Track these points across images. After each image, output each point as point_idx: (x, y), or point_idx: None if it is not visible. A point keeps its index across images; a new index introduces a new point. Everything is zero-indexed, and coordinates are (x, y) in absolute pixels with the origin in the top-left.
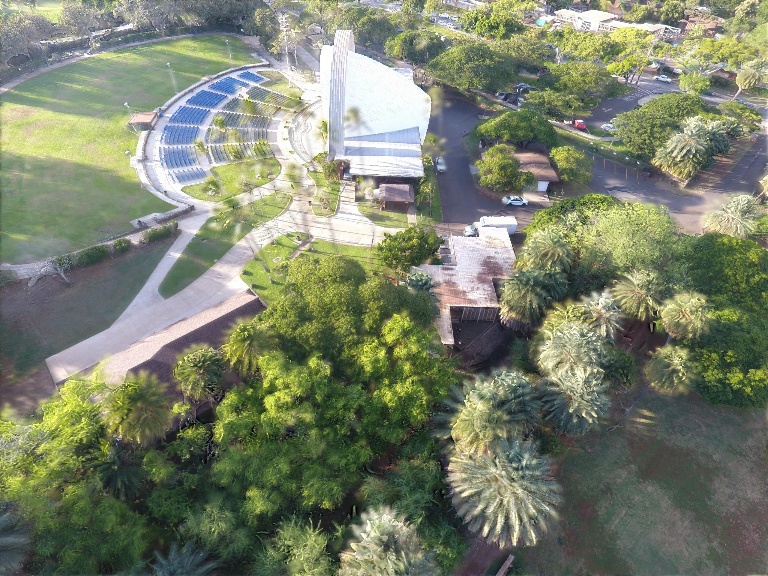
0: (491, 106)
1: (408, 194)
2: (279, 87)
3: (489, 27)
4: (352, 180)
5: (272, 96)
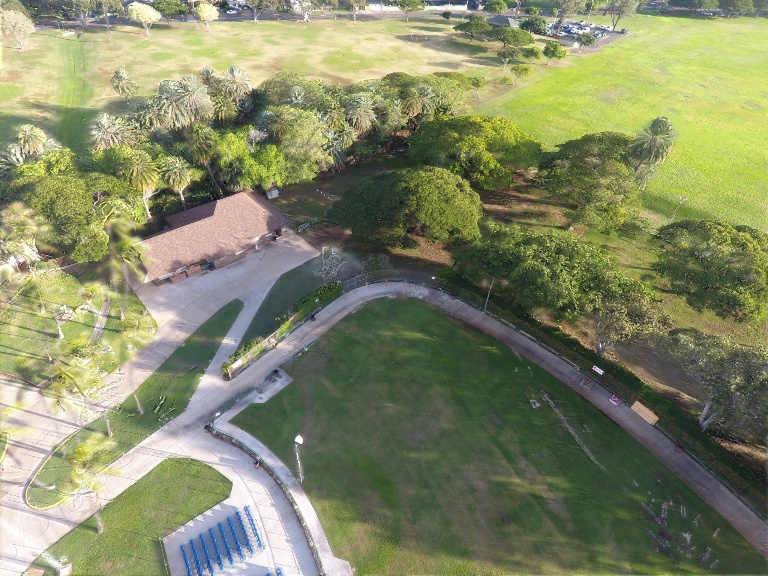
0: None
1: None
2: None
3: None
4: None
5: None
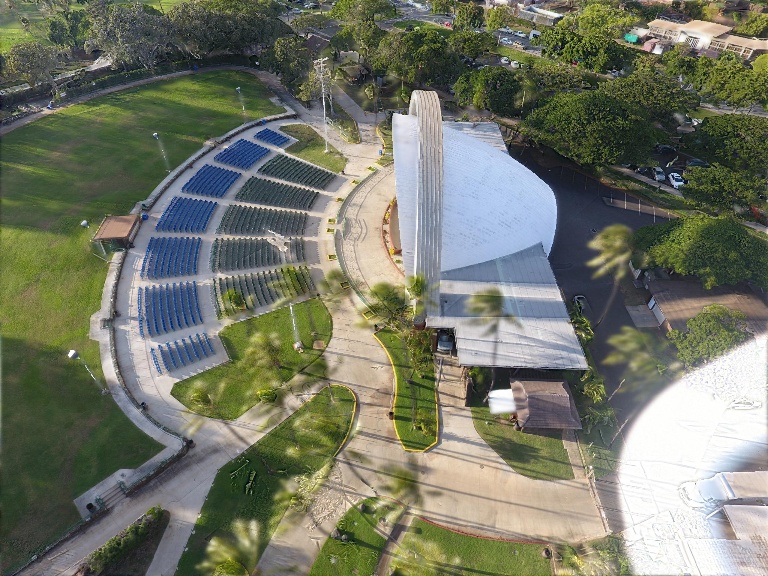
0: (617, 181)
1: (570, 412)
2: (312, 153)
3: (584, 53)
4: (452, 353)
5: (304, 171)
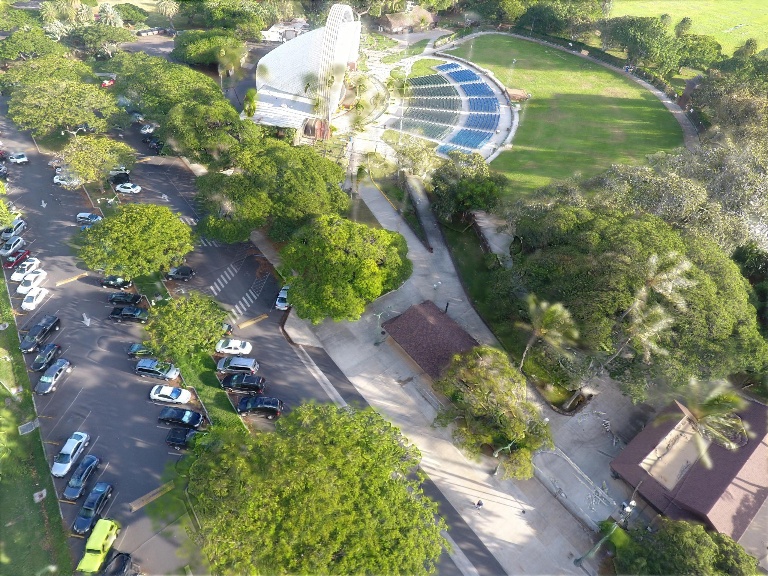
0: None
1: None
2: None
3: None
4: None
5: (416, 126)
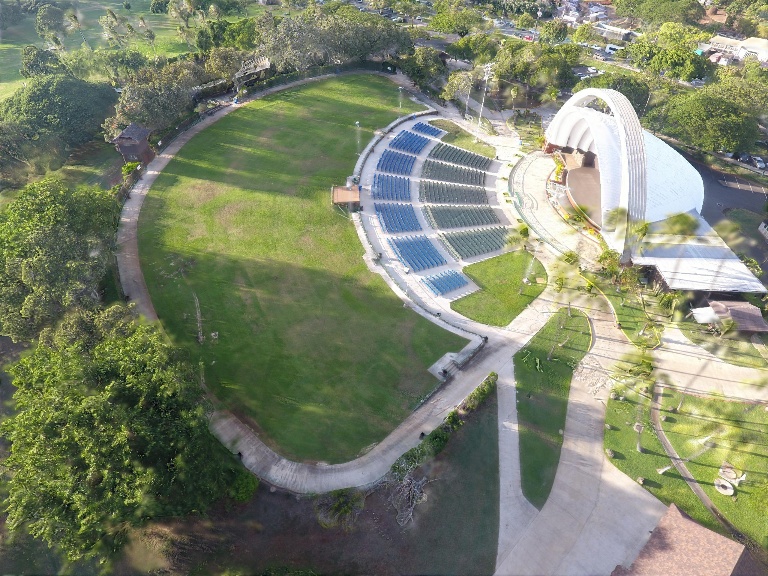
0: (725, 167)
1: None
2: (463, 142)
3: (672, 64)
4: (647, 287)
5: (466, 156)
